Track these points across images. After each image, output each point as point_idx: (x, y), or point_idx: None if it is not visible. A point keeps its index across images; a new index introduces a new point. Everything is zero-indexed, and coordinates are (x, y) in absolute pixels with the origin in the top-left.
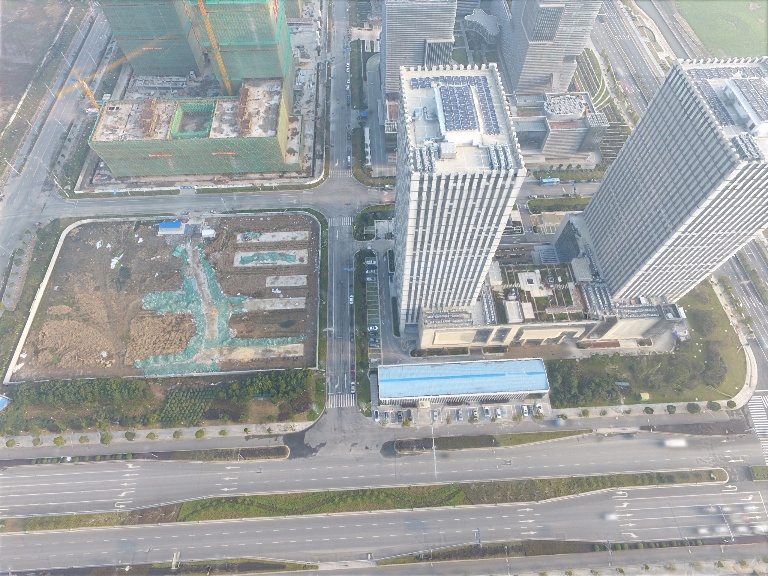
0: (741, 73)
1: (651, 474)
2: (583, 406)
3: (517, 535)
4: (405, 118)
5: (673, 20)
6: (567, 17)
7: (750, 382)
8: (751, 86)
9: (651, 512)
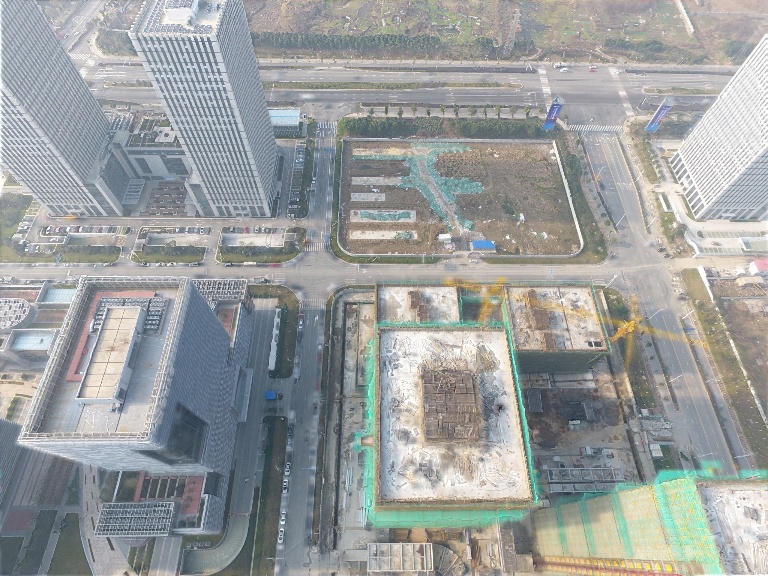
0: None
1: None
2: None
3: None
4: (226, 4)
5: None
6: None
7: None
8: None
9: None
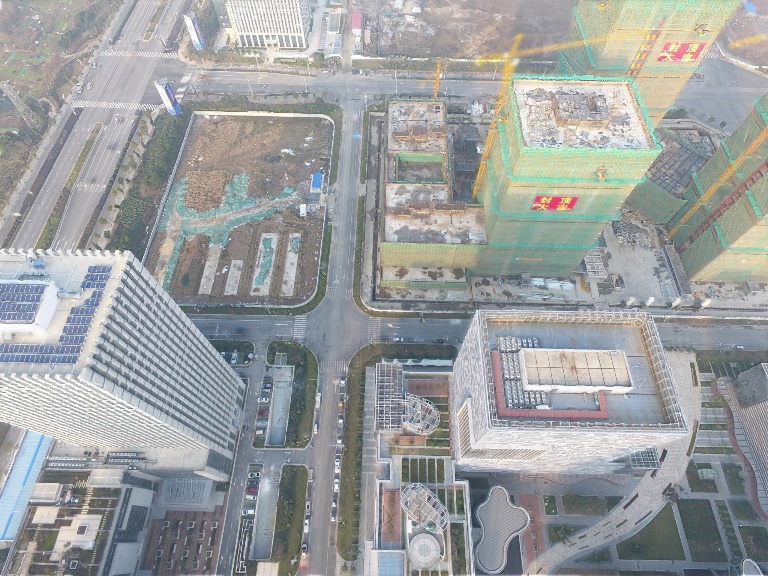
0: None
1: None
2: None
3: None
4: None
5: None
6: None
7: None
8: None
9: None
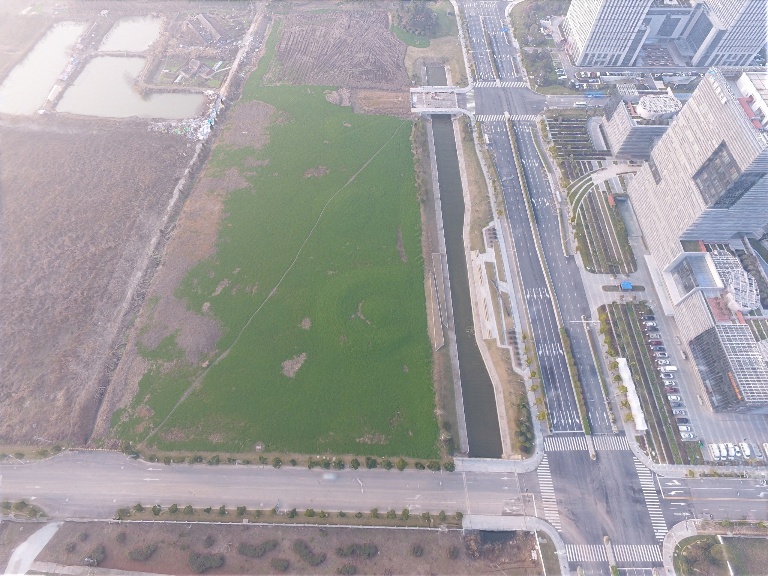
0: None
1: None
2: None
3: None
4: None
5: (446, 335)
6: None
7: (512, 5)
8: None
9: None
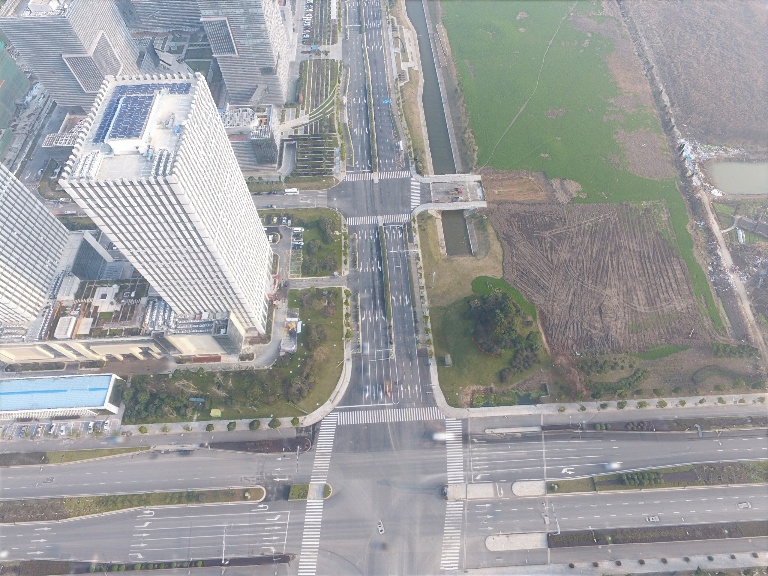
0: (168, 89)
1: (182, 493)
2: (153, 422)
3: (22, 555)
4: None
5: (435, 30)
6: (237, 30)
7: (334, 398)
8: (135, 103)
9: (169, 532)
